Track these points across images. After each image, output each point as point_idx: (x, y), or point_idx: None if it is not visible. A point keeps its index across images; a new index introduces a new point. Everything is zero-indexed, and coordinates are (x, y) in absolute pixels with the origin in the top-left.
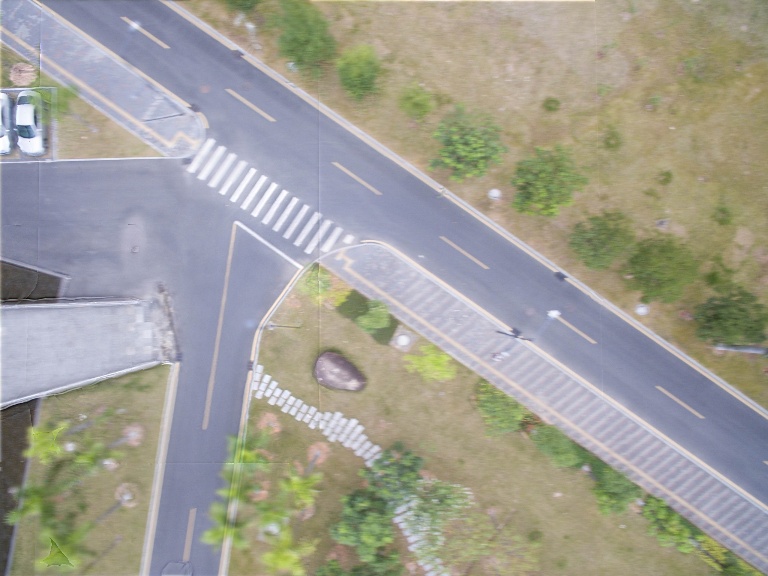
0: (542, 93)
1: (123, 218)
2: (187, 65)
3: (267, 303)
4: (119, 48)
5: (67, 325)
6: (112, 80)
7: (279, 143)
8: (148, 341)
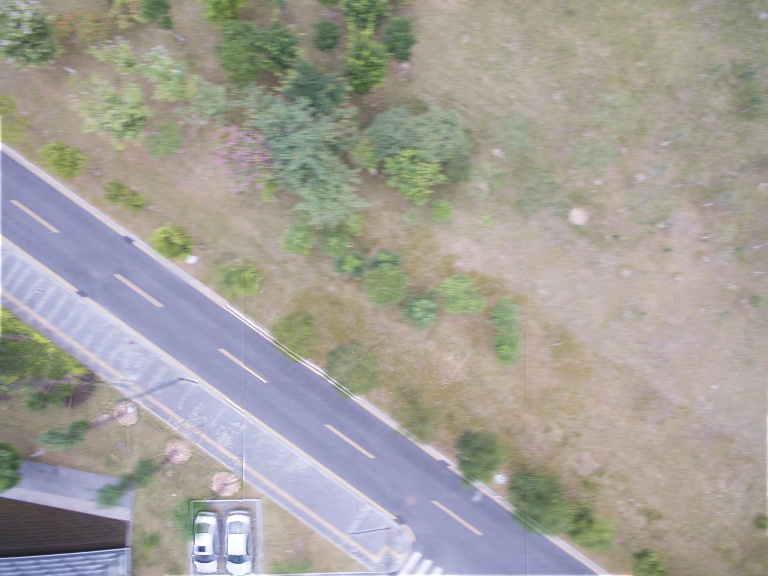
0: (753, 509)
1: None
2: (393, 476)
3: None
4: (323, 457)
5: None
6: (317, 491)
7: (486, 557)
8: None
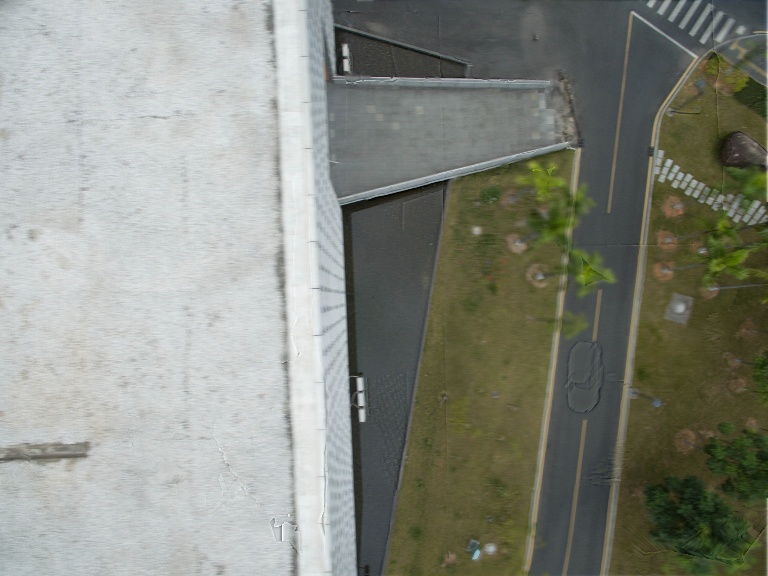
0: None
1: (522, 7)
2: None
3: (665, 91)
4: None
5: (477, 107)
6: None
7: None
8: (551, 127)
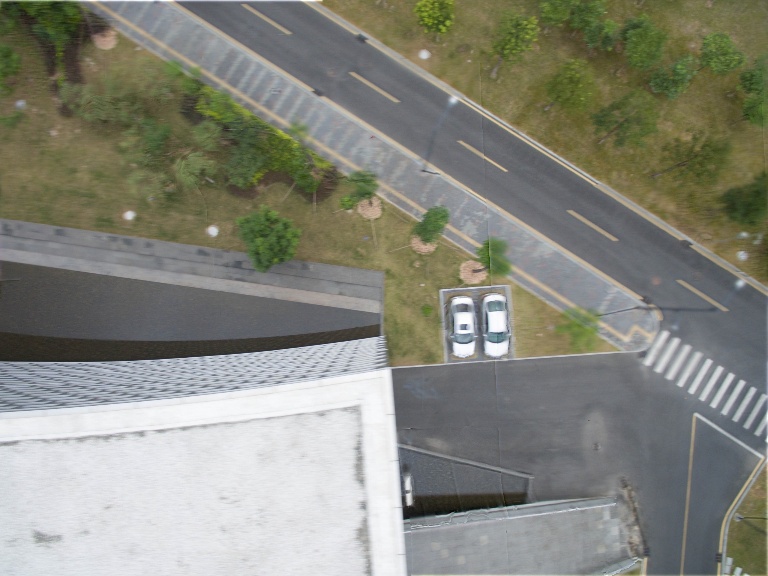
0: None
1: (582, 414)
2: (637, 257)
3: (732, 495)
4: (567, 242)
5: (542, 528)
6: (563, 275)
7: (733, 333)
8: (616, 538)
